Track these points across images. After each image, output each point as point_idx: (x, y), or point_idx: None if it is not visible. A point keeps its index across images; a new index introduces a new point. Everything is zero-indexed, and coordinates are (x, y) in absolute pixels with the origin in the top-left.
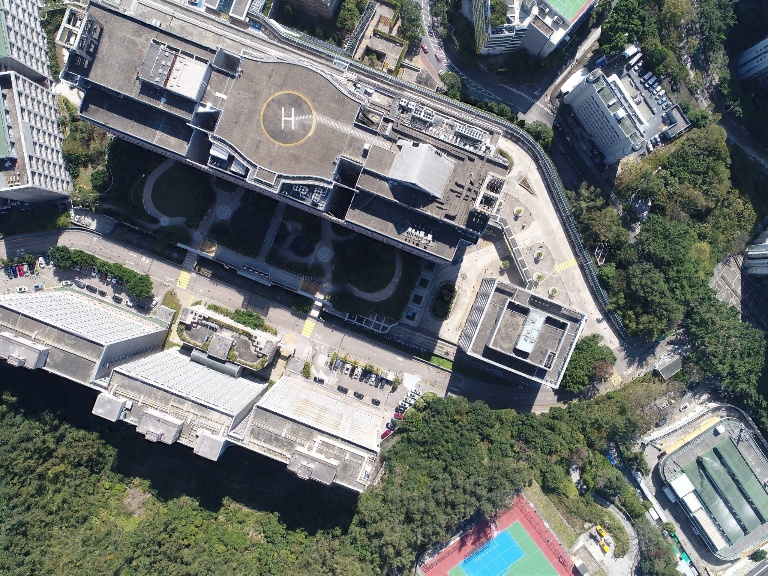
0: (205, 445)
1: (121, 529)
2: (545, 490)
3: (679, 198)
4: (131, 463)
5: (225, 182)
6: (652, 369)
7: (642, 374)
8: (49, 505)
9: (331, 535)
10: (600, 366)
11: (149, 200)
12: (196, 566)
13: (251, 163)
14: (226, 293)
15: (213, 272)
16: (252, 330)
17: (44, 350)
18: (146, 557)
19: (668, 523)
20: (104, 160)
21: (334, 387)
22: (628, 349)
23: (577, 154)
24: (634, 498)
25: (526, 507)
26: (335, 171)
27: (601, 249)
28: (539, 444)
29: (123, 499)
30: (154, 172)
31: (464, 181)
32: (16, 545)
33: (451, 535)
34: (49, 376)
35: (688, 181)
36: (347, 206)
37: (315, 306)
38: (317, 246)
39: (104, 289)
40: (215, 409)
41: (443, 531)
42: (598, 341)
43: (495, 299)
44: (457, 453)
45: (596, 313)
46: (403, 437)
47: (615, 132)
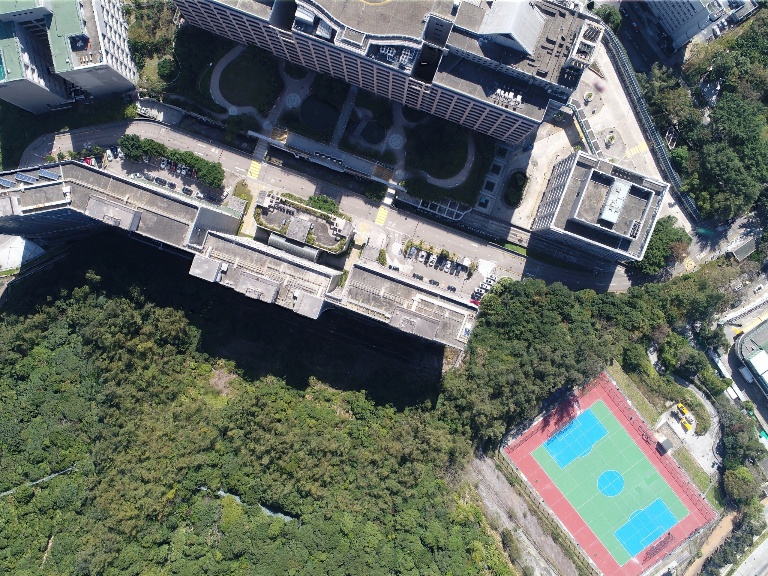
0: (305, 303)
1: (210, 407)
2: (626, 369)
3: (750, 78)
4: (214, 346)
5: (295, 67)
6: (725, 253)
7: (715, 258)
8: (138, 382)
9: (420, 410)
10: (677, 245)
11: (217, 90)
12: (291, 436)
13: (338, 24)
14: (298, 182)
15: (284, 162)
16: (329, 214)
17: (138, 211)
18: (240, 430)
19: (748, 401)
20: (171, 48)
21: (409, 275)
22: (700, 233)
23: (644, 40)
24: (713, 377)
25: (609, 384)
26: (425, 29)
27: (672, 133)
28: (621, 321)
29: (209, 379)
30: (221, 61)
31: (555, 37)
32: (111, 417)
33: (538, 410)
34: (127, 262)
35: (758, 62)
36: (429, 76)
37: (388, 194)
38: (388, 133)
39: (173, 181)
40: (312, 270)
41: (534, 401)
42: (673, 223)
43: (576, 173)
44: (539, 331)
45: (668, 197)
46: (482, 321)
47: (690, 5)
